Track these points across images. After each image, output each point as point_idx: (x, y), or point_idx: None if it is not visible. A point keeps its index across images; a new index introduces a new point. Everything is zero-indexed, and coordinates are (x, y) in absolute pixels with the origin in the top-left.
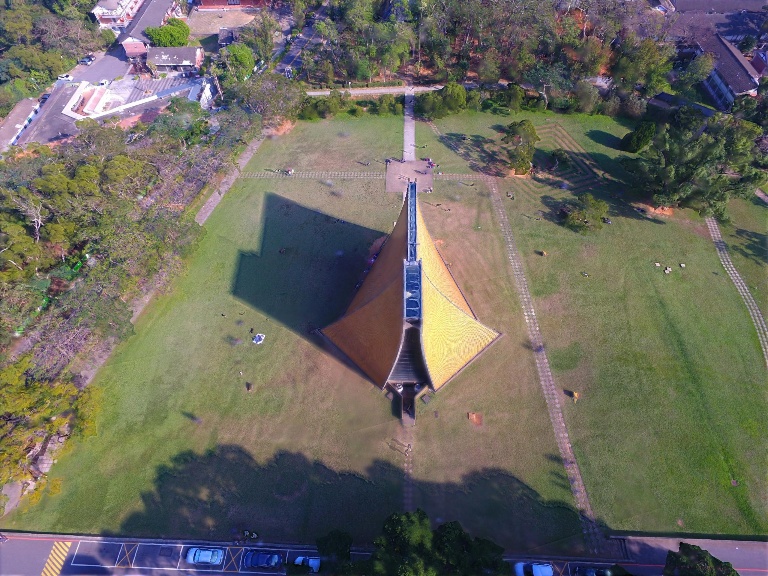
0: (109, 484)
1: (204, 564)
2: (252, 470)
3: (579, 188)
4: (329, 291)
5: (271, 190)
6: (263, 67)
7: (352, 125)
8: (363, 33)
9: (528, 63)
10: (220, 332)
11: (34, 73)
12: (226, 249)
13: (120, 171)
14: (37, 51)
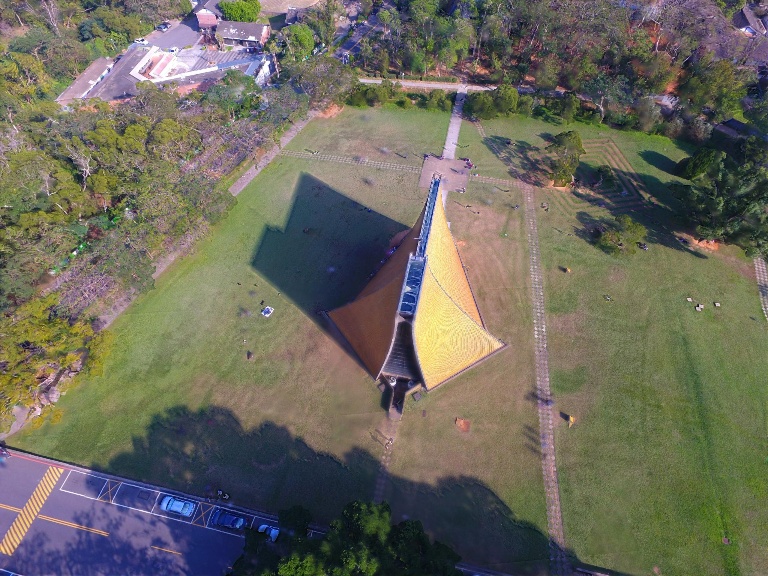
0: (106, 423)
1: (175, 513)
2: (237, 435)
3: (620, 209)
4: (343, 276)
5: (307, 170)
6: (323, 50)
7: (398, 116)
8: (423, 25)
9: (589, 73)
10: (233, 299)
11: (114, 34)
12: (254, 221)
13: (165, 134)
14: (119, 14)
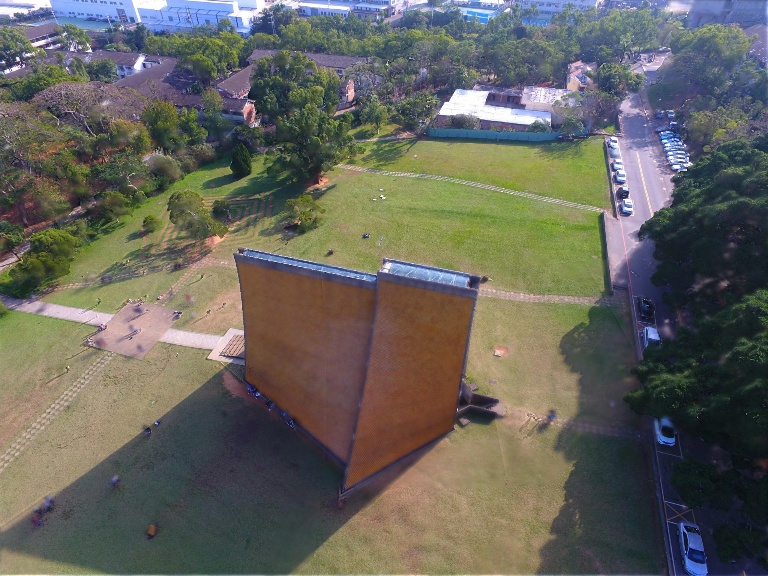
0: None
1: None
2: None
3: (266, 212)
4: (279, 465)
5: None
6: None
7: None
8: None
9: (85, 173)
10: None
11: None
12: None
13: None
14: None
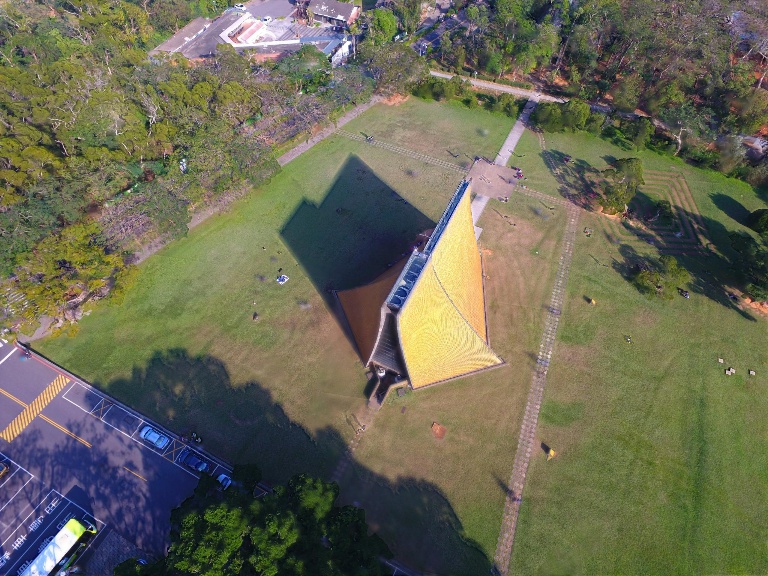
0: (115, 348)
1: (150, 443)
2: (224, 386)
3: (670, 249)
4: (362, 260)
5: (357, 153)
6: (405, 38)
7: (461, 115)
8: (506, 26)
9: (673, 100)
10: (254, 261)
11: None
12: (293, 192)
13: (228, 95)
14: None
